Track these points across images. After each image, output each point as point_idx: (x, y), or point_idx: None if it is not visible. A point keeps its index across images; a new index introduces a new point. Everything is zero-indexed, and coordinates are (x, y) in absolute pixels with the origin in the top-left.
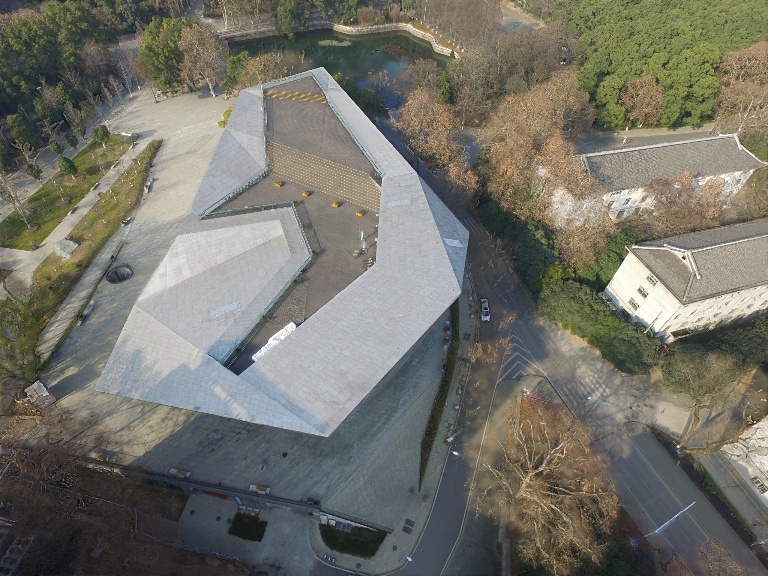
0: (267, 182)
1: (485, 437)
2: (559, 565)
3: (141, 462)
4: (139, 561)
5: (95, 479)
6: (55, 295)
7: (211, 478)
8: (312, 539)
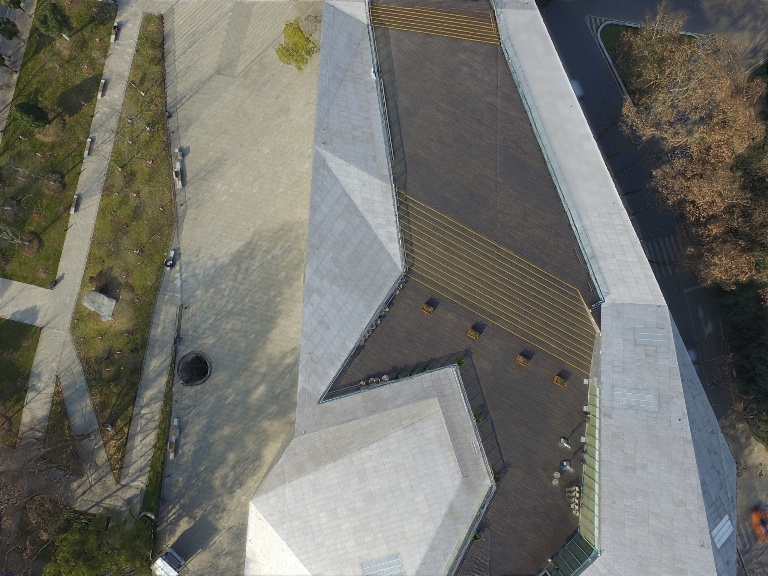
0: (407, 301)
1: None
2: None
3: None
4: None
5: None
6: (119, 389)
7: None
8: None
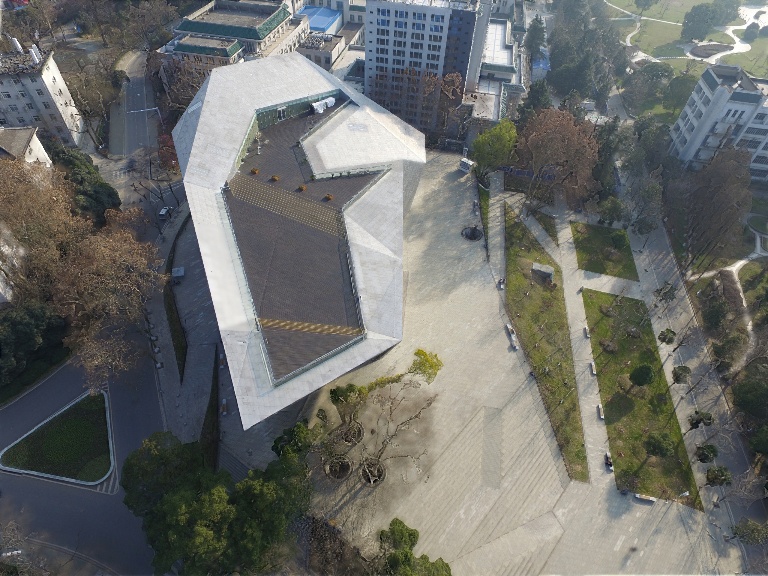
0: (341, 201)
1: None
2: None
3: None
4: None
5: None
6: None
7: None
8: None
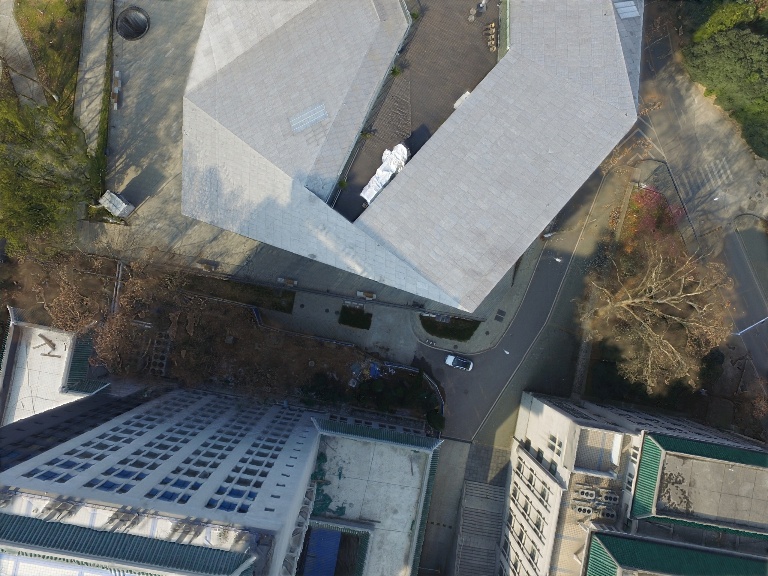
0: None
1: (584, 232)
2: (652, 377)
3: (247, 271)
4: (268, 345)
5: (203, 279)
6: (62, 57)
7: (318, 285)
8: (414, 327)
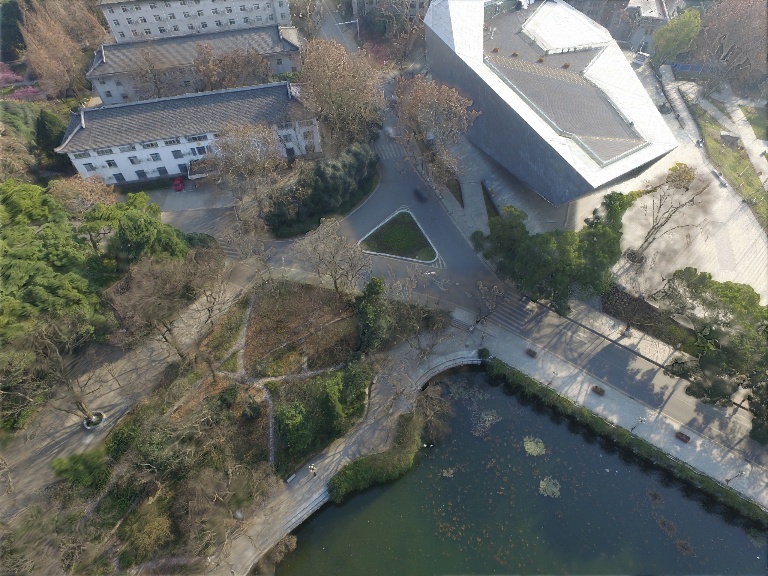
0: (578, 68)
1: (410, 66)
2: None
3: None
4: None
5: None
6: None
7: None
8: None
